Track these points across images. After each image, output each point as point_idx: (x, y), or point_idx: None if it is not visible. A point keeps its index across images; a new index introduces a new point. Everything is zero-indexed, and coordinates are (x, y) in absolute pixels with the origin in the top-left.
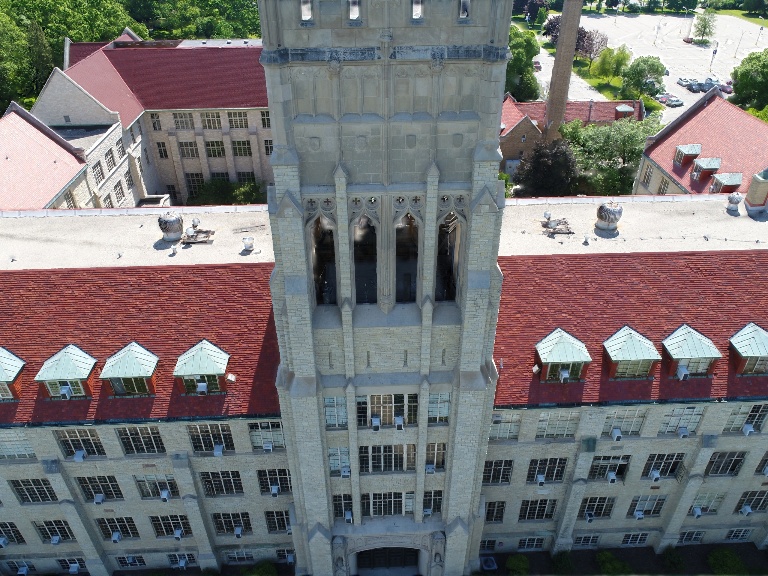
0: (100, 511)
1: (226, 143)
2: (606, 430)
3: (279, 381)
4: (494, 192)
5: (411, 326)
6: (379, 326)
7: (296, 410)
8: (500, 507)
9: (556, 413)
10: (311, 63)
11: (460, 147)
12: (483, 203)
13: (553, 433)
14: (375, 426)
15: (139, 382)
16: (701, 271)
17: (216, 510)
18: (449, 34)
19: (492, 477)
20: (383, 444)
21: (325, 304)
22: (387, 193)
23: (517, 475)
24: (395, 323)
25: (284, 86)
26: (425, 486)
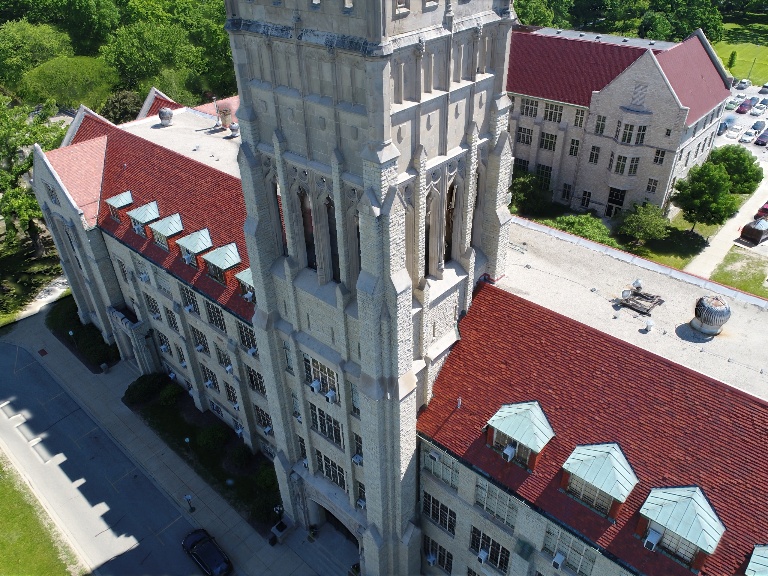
0: (201, 358)
1: (535, 133)
2: (550, 547)
3: (256, 307)
4: (380, 196)
5: (331, 305)
6: (310, 293)
7: (257, 336)
8: (450, 558)
9: (494, 488)
10: (254, 34)
11: (357, 141)
12: (364, 203)
13: (494, 510)
14: (311, 386)
15: (220, 271)
16: (767, 435)
17: (255, 402)
18: (339, 23)
19: (440, 519)
20: (322, 409)
21: (286, 256)
22: (309, 168)
23: (460, 533)
24: (321, 296)
25: (239, 51)
26: (356, 474)
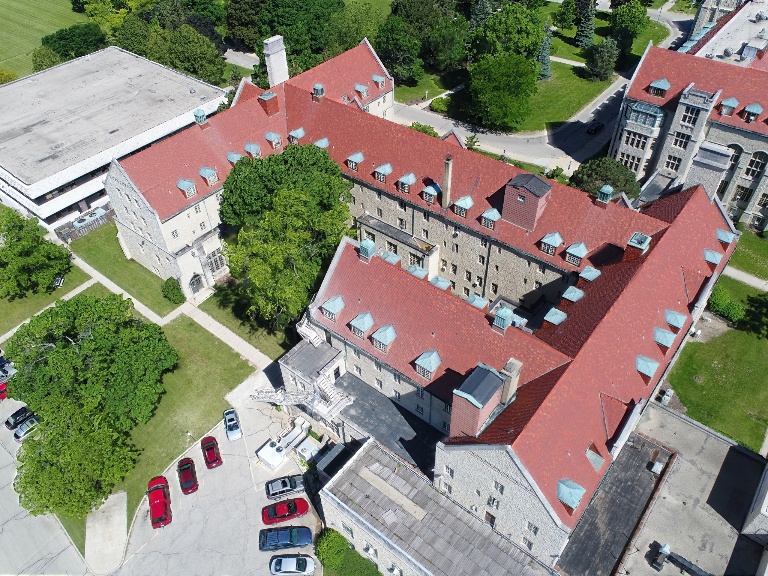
0: None
1: None
2: None
3: None
4: None
5: None
6: None
7: None
8: None
9: None
10: None
11: None
12: None
13: None
14: None
15: None
16: None
17: None
18: None
19: None
20: None
21: None
22: None
23: None
24: None
25: None
26: None
